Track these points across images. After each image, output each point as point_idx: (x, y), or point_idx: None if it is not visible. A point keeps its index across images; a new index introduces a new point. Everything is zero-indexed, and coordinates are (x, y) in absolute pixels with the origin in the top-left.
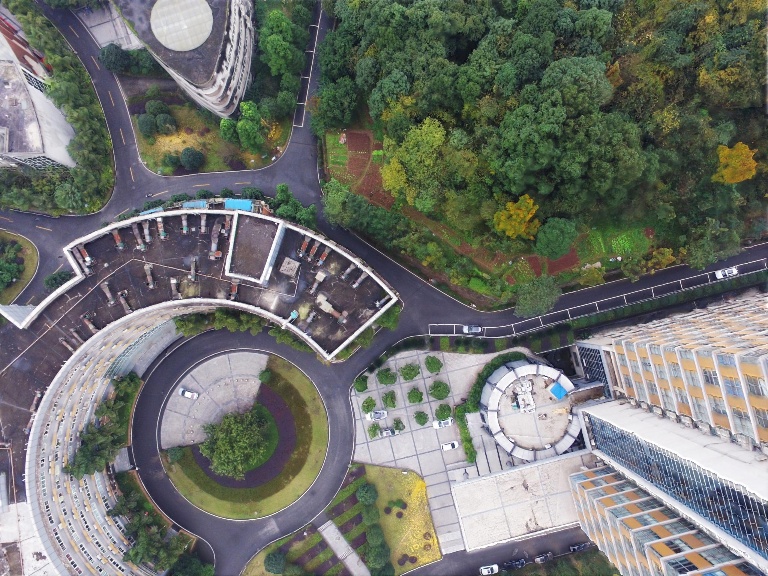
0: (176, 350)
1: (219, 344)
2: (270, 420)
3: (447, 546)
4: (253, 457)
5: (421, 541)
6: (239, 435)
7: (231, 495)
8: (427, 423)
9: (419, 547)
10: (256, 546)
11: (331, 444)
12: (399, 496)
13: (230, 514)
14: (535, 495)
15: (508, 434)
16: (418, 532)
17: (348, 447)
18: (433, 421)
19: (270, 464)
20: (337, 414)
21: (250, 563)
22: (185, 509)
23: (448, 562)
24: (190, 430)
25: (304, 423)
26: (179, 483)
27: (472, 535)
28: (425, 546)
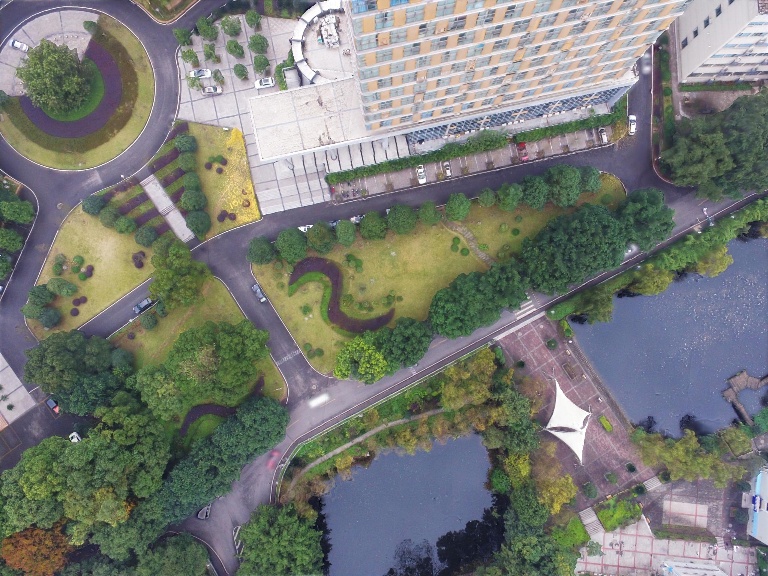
0: (9, 4)
1: (51, 2)
2: (96, 73)
3: (266, 205)
4: (66, 83)
5: (240, 198)
6: (50, 55)
7: (56, 144)
8: (250, 84)
9: (238, 204)
10: (79, 196)
11: (156, 102)
12: (220, 153)
13: (55, 164)
14: (329, 111)
15: (313, 68)
16: (237, 188)
17: (173, 105)
18: (255, 81)
19: (95, 115)
20: (163, 74)
21: (72, 212)
22: (11, 158)
23: (268, 223)
24: (19, 81)
25: (130, 79)
26: (6, 132)
27: (266, 146)
28: (243, 201)
